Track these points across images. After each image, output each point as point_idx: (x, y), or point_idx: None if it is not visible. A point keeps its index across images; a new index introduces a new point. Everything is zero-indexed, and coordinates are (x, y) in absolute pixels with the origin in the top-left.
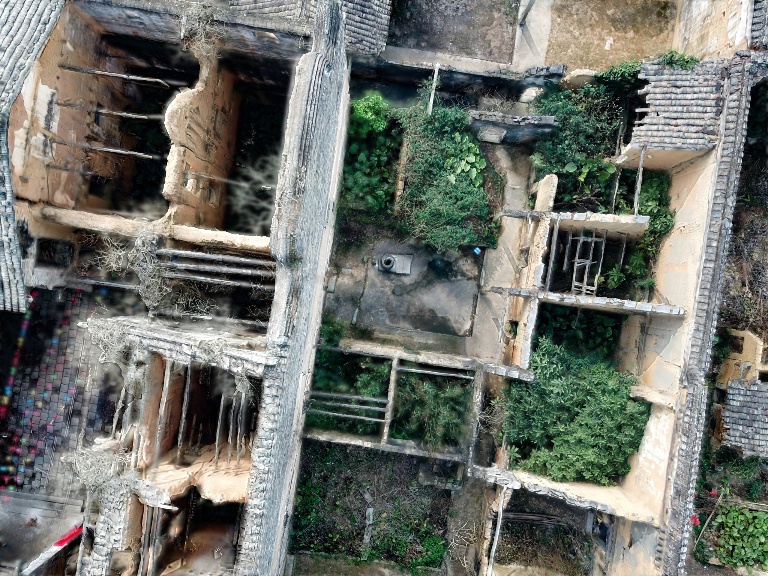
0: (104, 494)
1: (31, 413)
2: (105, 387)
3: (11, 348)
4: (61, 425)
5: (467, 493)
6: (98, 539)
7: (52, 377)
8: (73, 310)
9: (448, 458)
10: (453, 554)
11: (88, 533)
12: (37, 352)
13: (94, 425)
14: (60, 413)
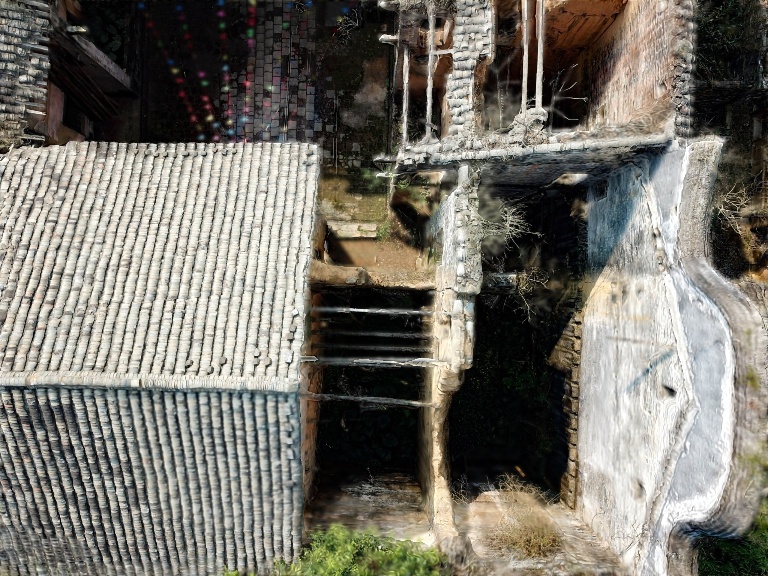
0: (459, 1)
1: (243, 121)
2: (320, 84)
3: (212, 53)
4: (278, 130)
5: (731, 153)
6: (459, 53)
7: (261, 79)
8: (275, 3)
9: (729, 86)
10: (724, 222)
11: (329, 232)
12: (241, 54)
13: (314, 126)
14: (275, 117)
